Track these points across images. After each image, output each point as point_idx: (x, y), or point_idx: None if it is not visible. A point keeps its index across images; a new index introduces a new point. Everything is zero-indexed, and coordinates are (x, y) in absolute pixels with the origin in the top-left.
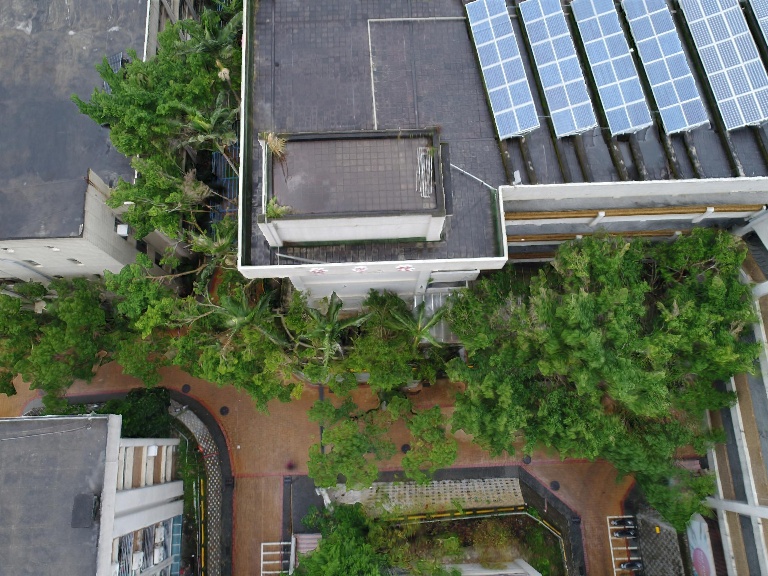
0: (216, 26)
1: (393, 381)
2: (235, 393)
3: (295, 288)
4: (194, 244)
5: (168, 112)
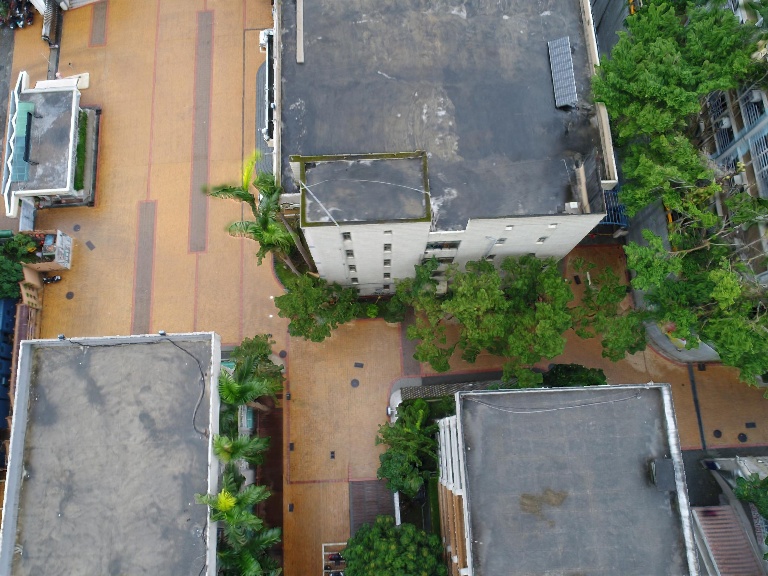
0: (723, 8)
1: None
2: (603, 371)
3: (765, 264)
4: (754, 218)
5: (709, 91)
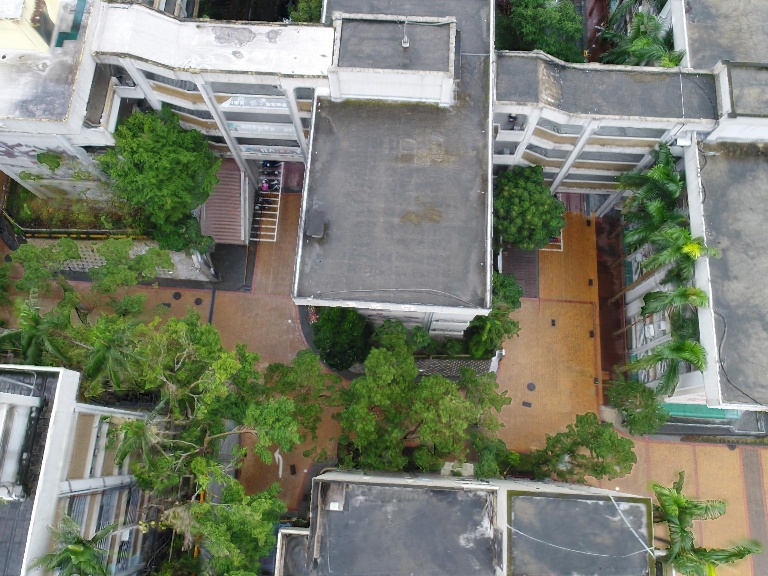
0: None
1: (49, 314)
2: None
3: None
4: None
5: None
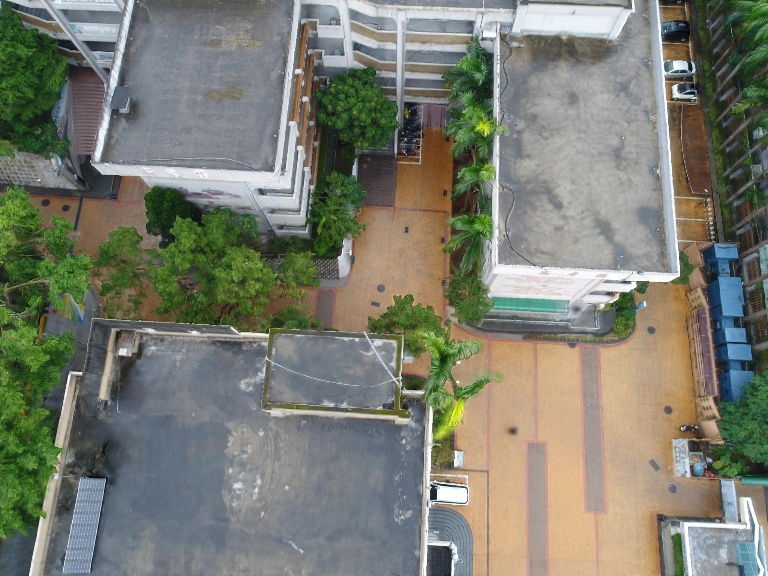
0: None
1: None
2: None
3: None
4: None
5: None
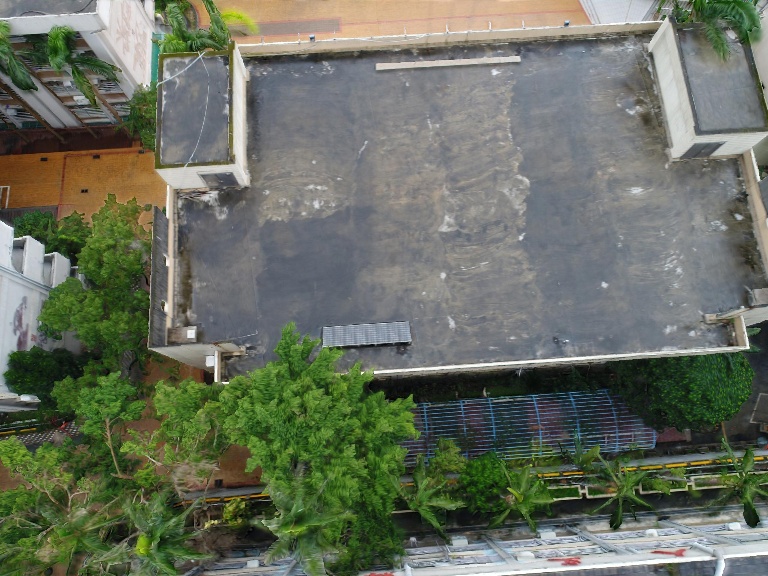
0: (385, 493)
1: None
2: None
3: None
4: None
5: None
